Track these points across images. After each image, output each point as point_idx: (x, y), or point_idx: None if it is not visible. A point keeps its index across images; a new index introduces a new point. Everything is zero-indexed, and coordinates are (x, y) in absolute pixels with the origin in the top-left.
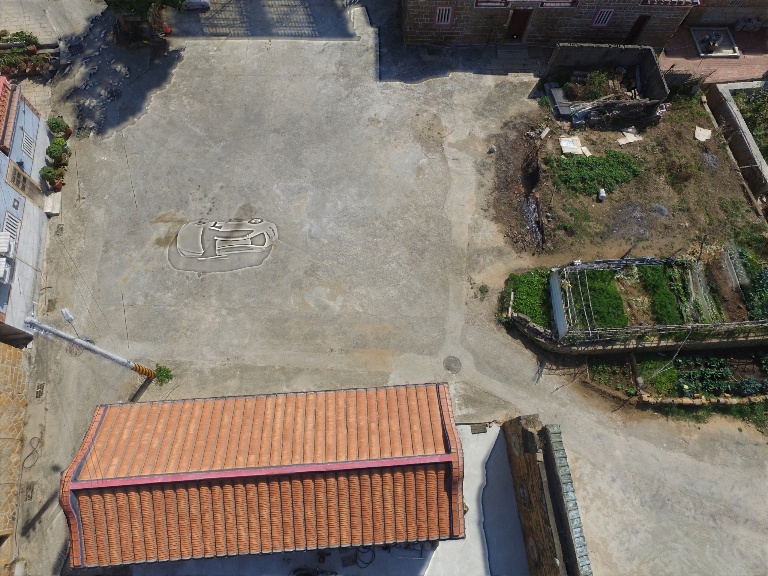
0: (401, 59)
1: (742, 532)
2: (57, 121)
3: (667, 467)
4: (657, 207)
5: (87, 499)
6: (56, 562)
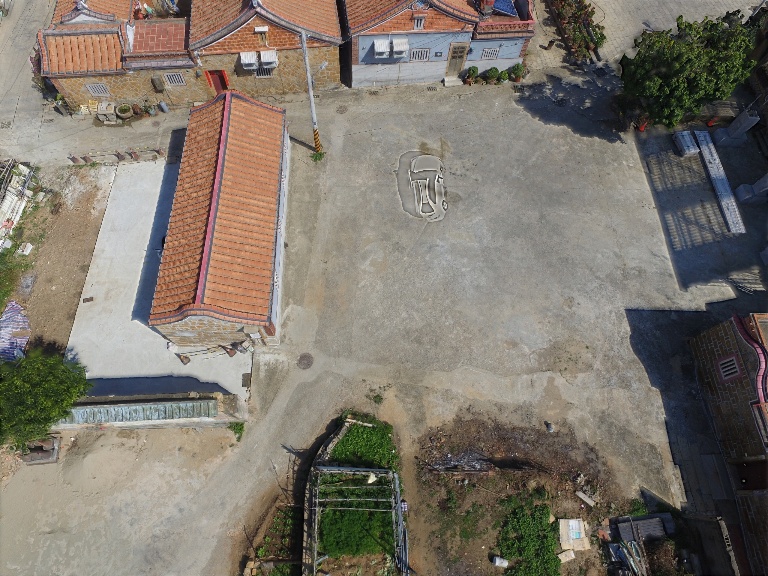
0: (665, 334)
1: None
2: (520, 68)
3: None
4: None
5: (222, 103)
6: None
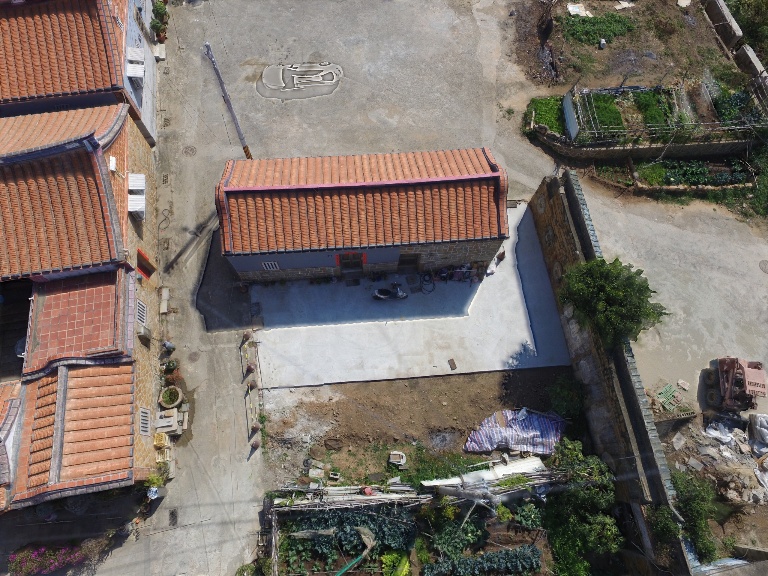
0: None
1: (716, 275)
2: None
3: (658, 233)
4: (647, 52)
5: (235, 202)
6: (192, 289)
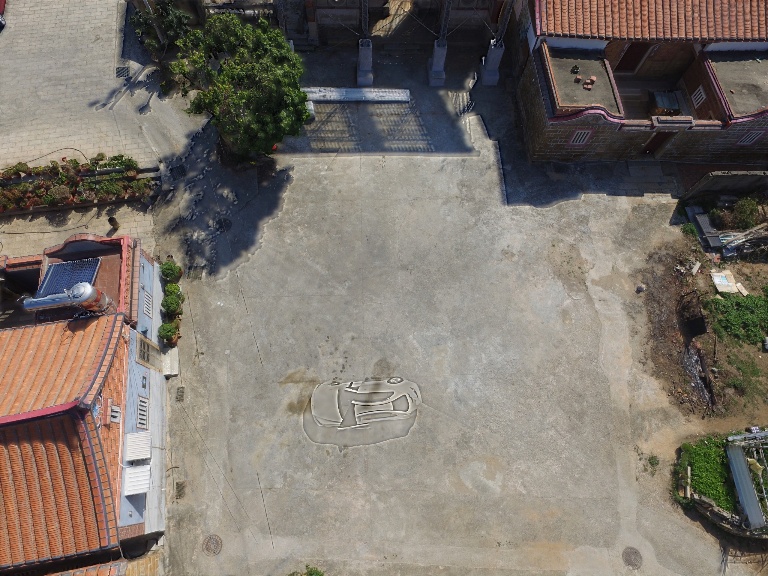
0: (527, 178)
1: None
2: (172, 267)
3: None
4: None
5: None
6: None
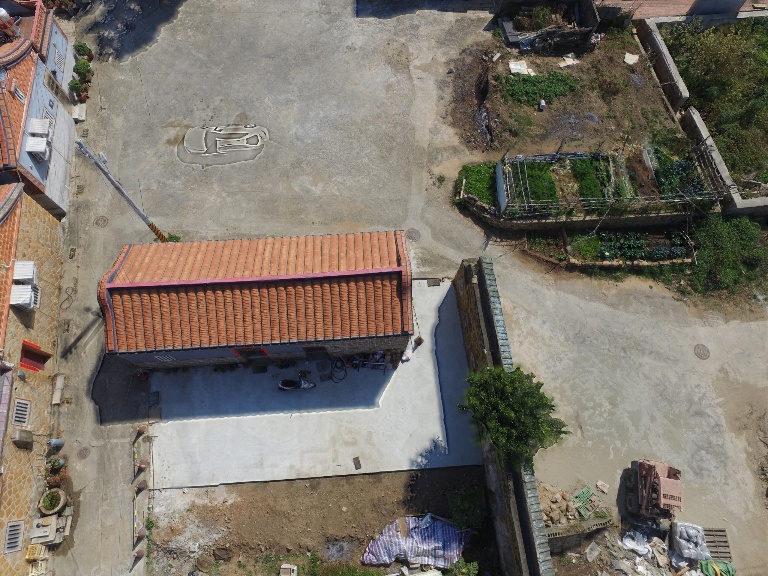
0: None
1: (647, 360)
2: (82, 44)
3: (588, 313)
4: (589, 115)
5: (119, 298)
6: (89, 376)
